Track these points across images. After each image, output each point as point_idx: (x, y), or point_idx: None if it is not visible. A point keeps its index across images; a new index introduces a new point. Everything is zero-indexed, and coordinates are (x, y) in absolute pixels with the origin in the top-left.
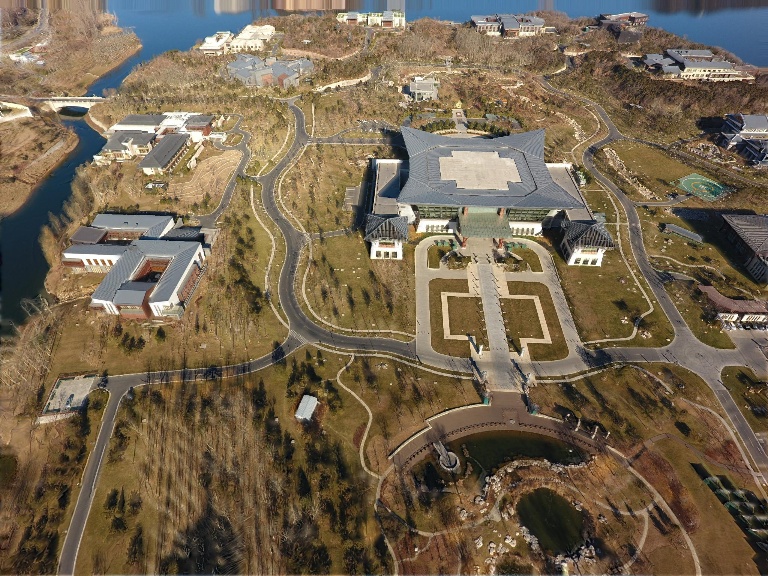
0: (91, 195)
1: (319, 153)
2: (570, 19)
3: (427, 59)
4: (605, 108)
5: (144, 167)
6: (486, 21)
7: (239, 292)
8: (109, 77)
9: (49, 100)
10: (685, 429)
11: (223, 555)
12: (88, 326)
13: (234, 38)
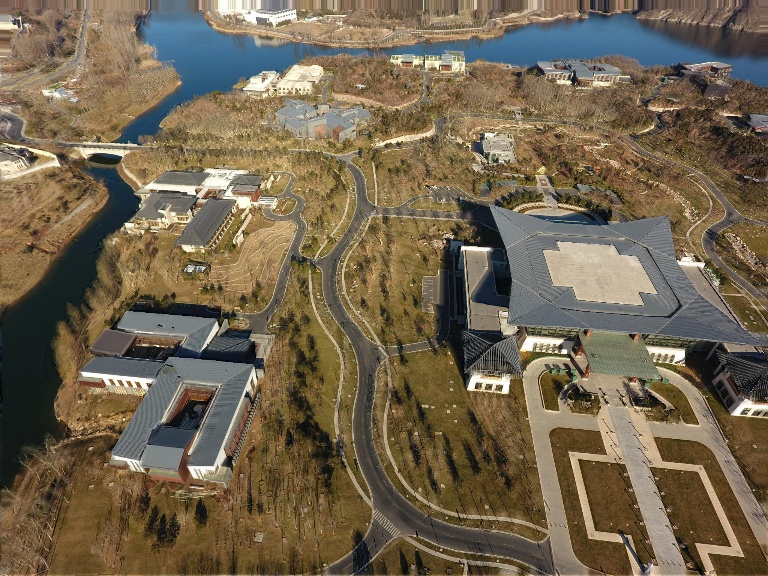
0: (119, 274)
1: (386, 228)
2: (642, 67)
3: (494, 110)
4: (712, 179)
5: (183, 244)
6: (554, 68)
7: (303, 443)
8: (145, 116)
9: (80, 146)
10: None
11: None
12: (105, 491)
13: (280, 78)
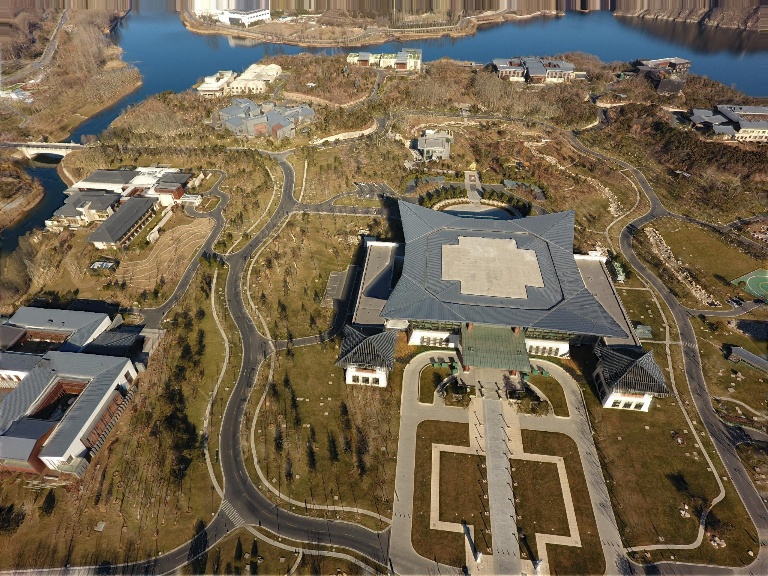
0: None
1: (304, 225)
2: (602, 63)
3: (441, 107)
4: (645, 174)
5: (93, 241)
6: (509, 65)
7: None
8: (101, 117)
9: (22, 146)
10: None
11: None
12: None
13: (236, 78)
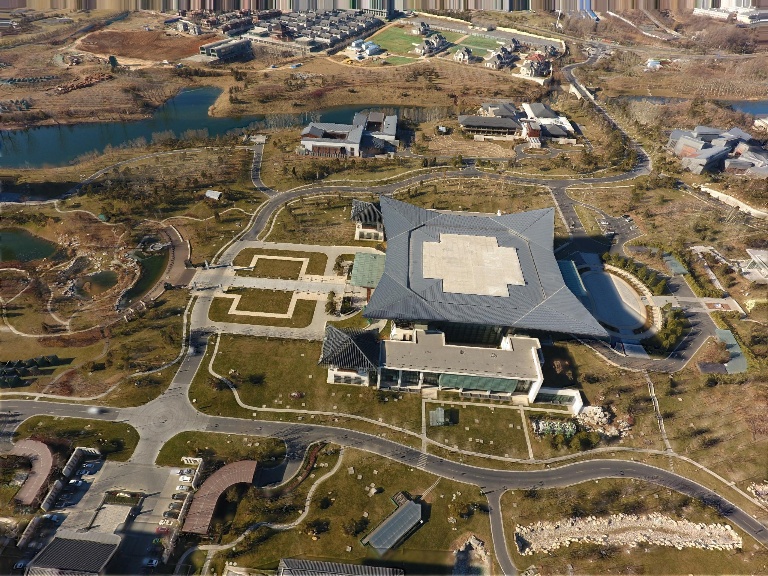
0: None
1: None
2: None
3: None
4: None
5: None
6: None
7: None
8: None
9: (573, 84)
10: (100, 366)
11: (147, 177)
12: None
13: None
